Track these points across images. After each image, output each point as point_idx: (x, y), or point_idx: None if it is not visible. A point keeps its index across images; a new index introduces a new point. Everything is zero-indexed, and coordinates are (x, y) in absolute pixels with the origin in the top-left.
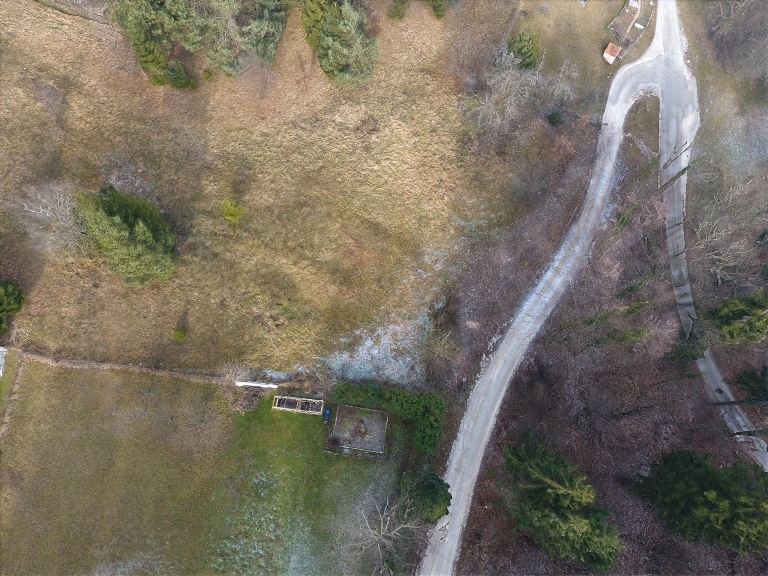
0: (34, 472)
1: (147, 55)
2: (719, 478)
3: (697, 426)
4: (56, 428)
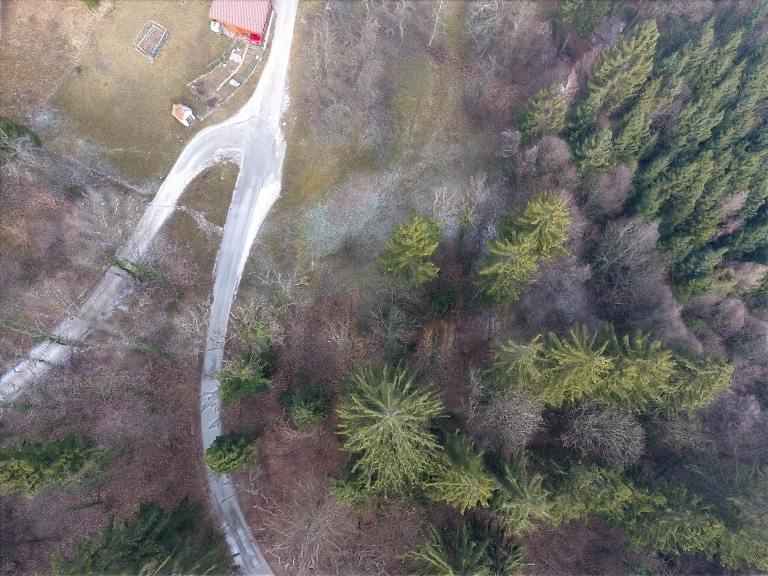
0: None
1: None
2: None
3: None
4: None
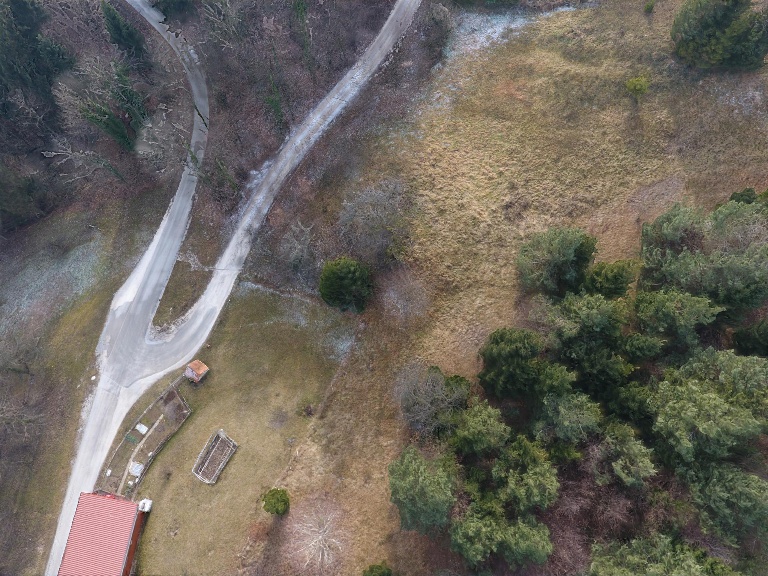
0: None
1: None
2: None
3: None
4: None
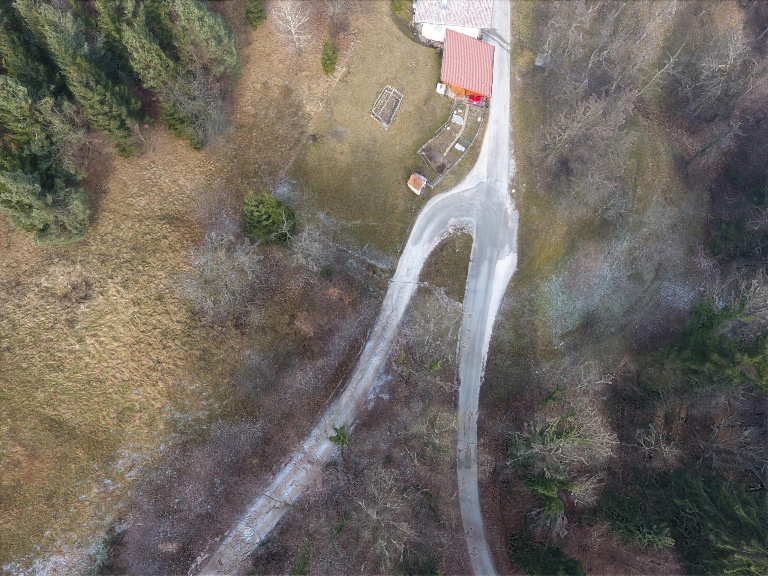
0: None
1: None
2: None
3: None
4: None
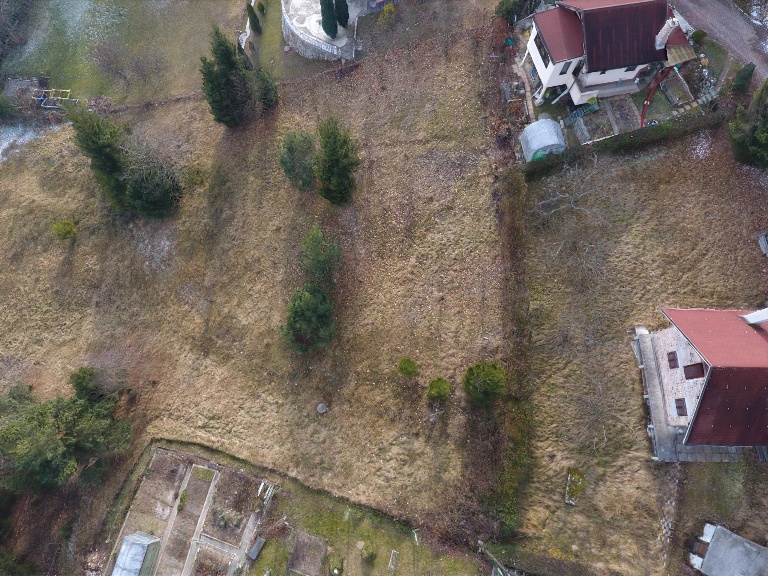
0: None
1: None
2: None
3: None
4: (208, 56)
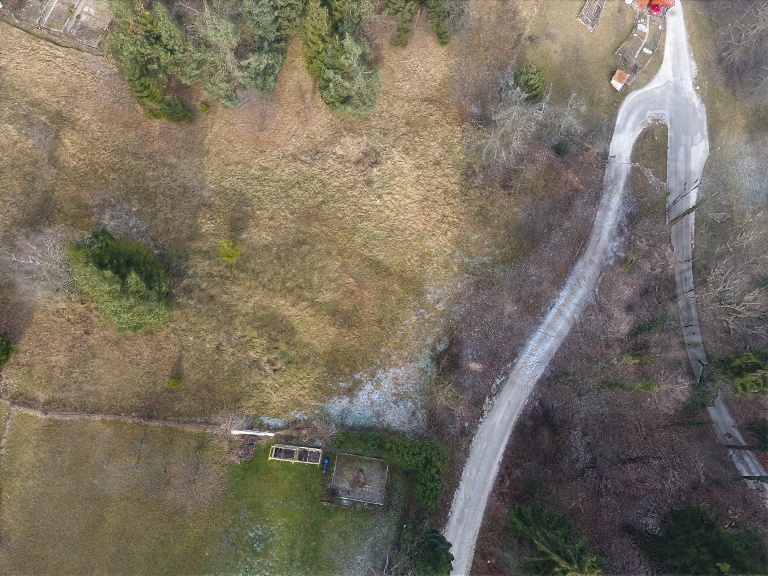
0: (21, 531)
1: (142, 90)
2: (732, 548)
3: (705, 469)
4: (45, 484)
